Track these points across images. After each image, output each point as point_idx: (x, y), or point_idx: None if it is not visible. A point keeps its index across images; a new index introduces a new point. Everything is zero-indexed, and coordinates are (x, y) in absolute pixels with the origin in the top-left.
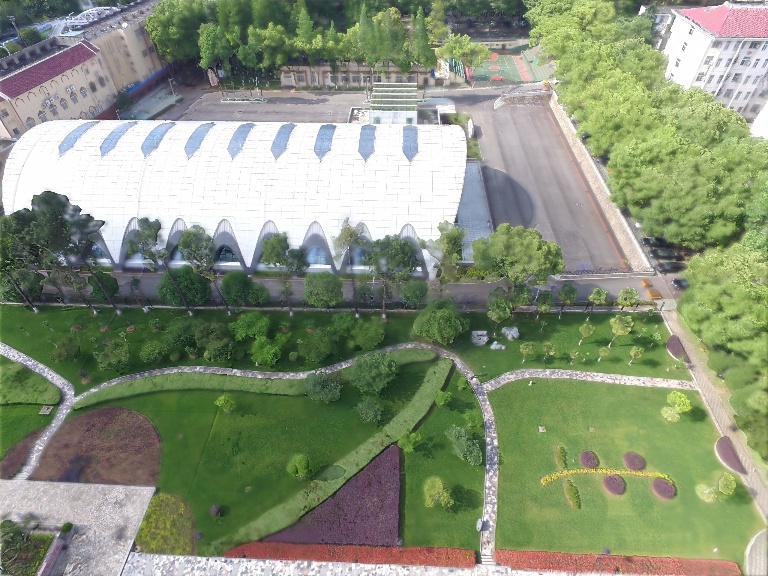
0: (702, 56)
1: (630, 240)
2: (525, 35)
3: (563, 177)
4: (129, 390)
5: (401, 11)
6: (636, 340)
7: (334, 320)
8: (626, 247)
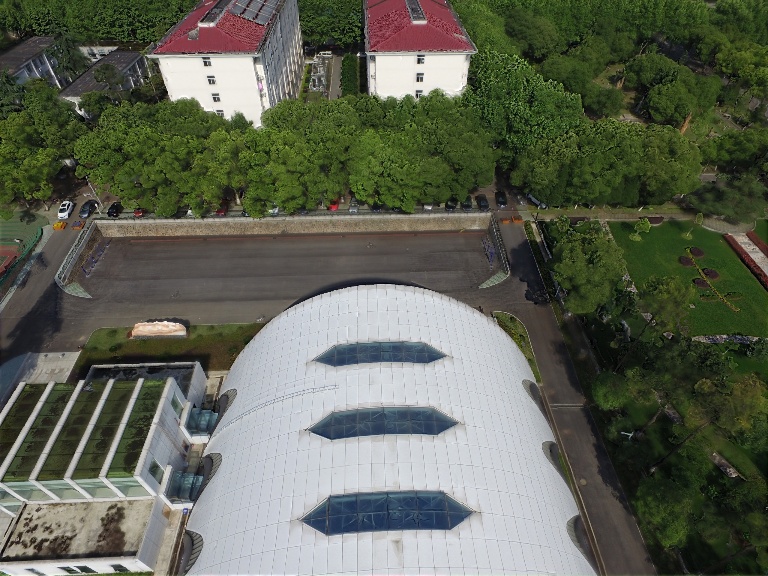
0: (253, 76)
1: (444, 219)
2: None
3: (312, 250)
4: None
5: None
6: None
7: (695, 490)
8: (445, 225)
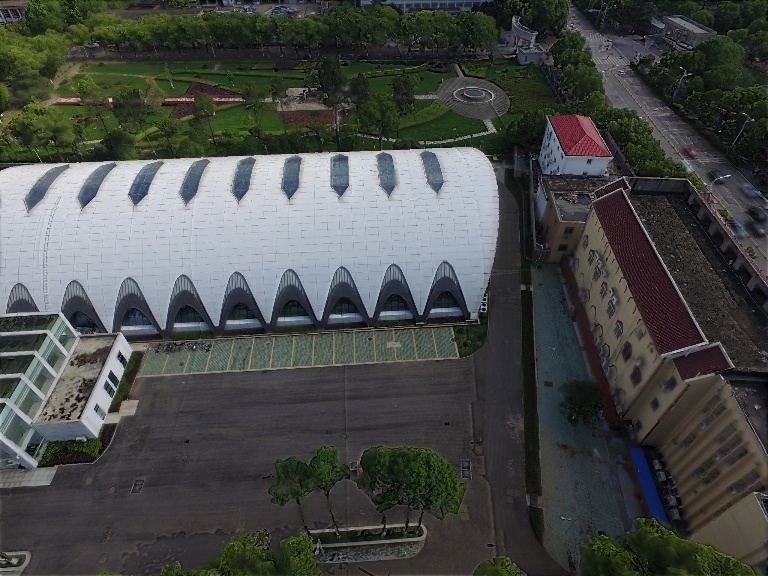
0: None
1: None
2: None
3: None
4: (306, 129)
5: None
6: (1, 152)
7: None
8: None
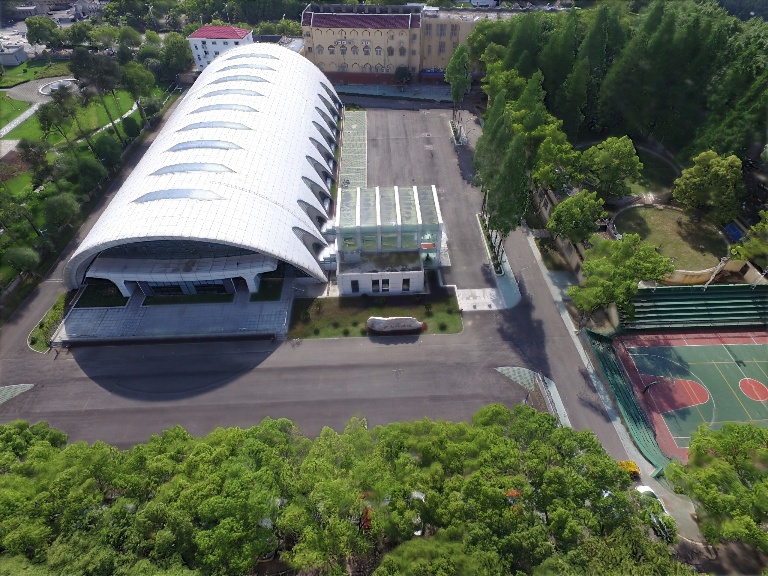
0: None
1: None
2: None
3: None
4: None
5: (762, 175)
6: None
7: None
8: None
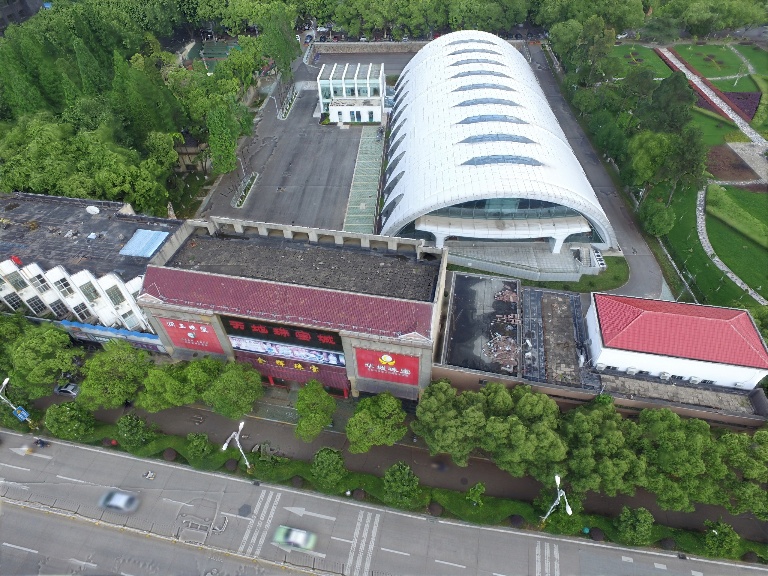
0: None
1: None
2: (174, 45)
3: None
4: None
5: None
6: None
7: None
8: None
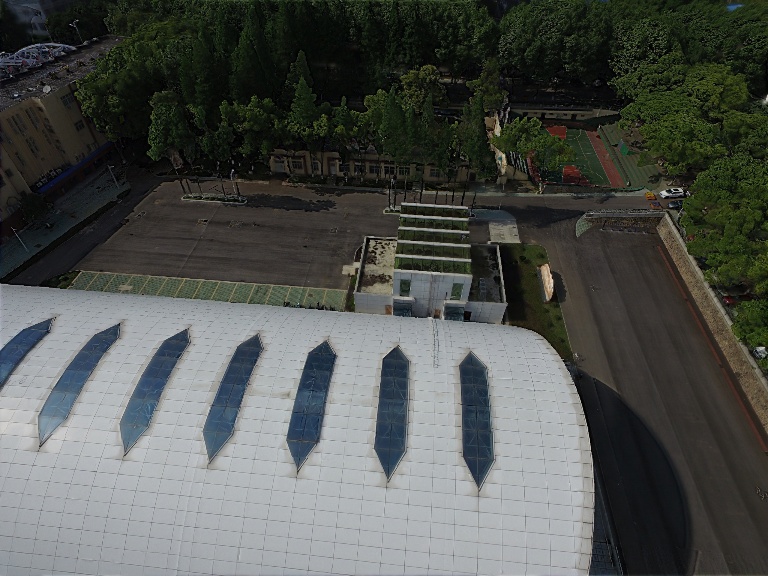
0: None
1: None
2: (602, 101)
3: (716, 409)
4: None
5: (440, 69)
6: None
7: None
8: None
